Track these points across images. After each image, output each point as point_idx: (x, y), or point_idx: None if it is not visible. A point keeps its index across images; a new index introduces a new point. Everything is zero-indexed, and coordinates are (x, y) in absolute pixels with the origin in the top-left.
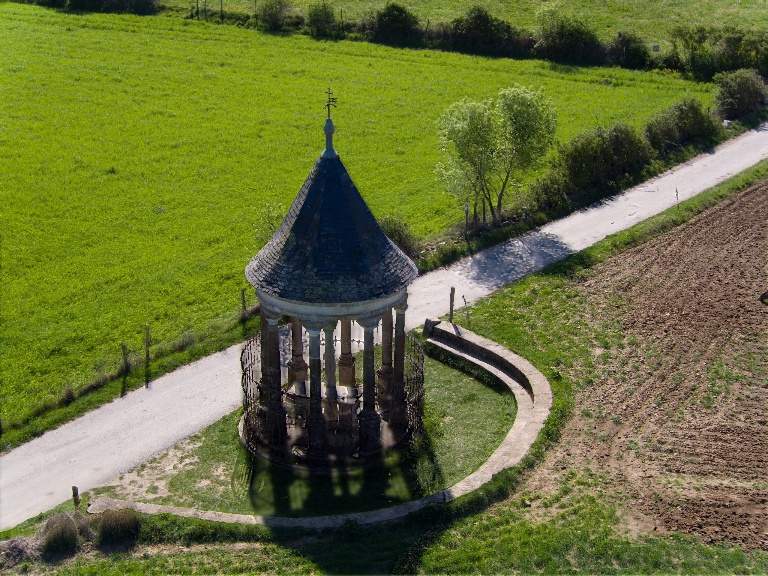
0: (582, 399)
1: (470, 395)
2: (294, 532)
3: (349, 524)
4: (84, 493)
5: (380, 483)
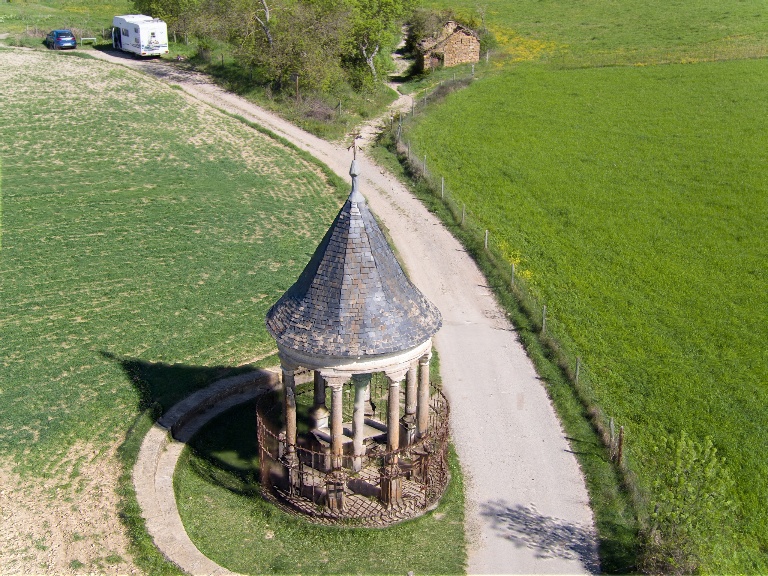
0: (134, 575)
1: (279, 566)
2: None
3: (201, 379)
4: (439, 385)
5: (249, 456)
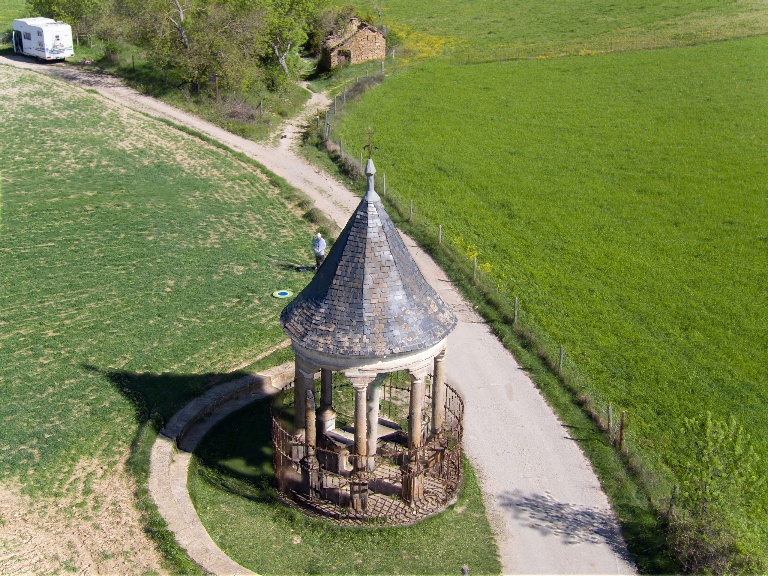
0: None
1: (314, 570)
2: (225, 377)
3: (195, 387)
4: None
5: (257, 462)
